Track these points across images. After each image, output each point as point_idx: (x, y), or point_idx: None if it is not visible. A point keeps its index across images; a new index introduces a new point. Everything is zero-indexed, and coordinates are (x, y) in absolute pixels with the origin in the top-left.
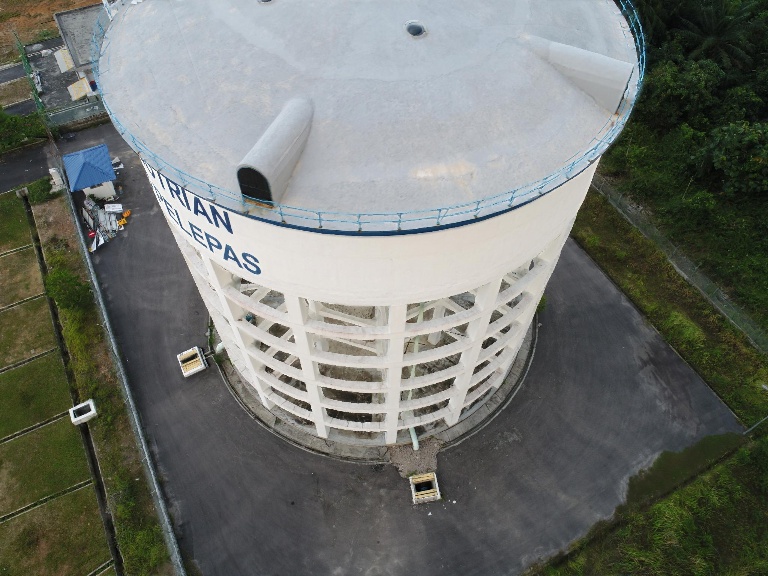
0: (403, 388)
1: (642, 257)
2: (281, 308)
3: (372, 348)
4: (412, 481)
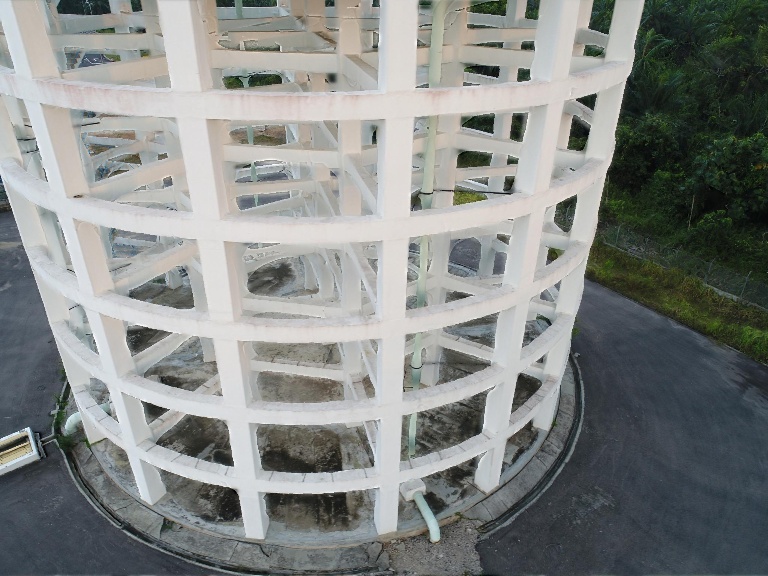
0: (410, 324)
1: (670, 288)
2: (172, 250)
3: (335, 370)
4: None
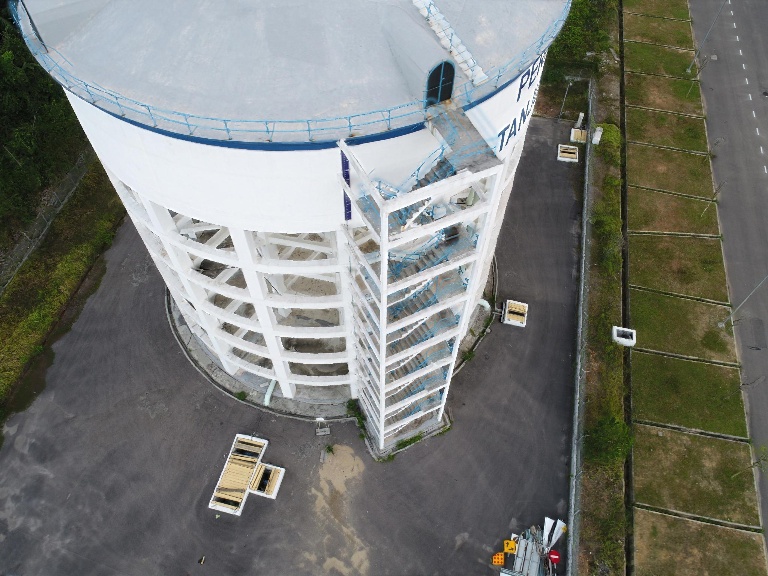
0: None
1: None
2: None
3: None
4: None
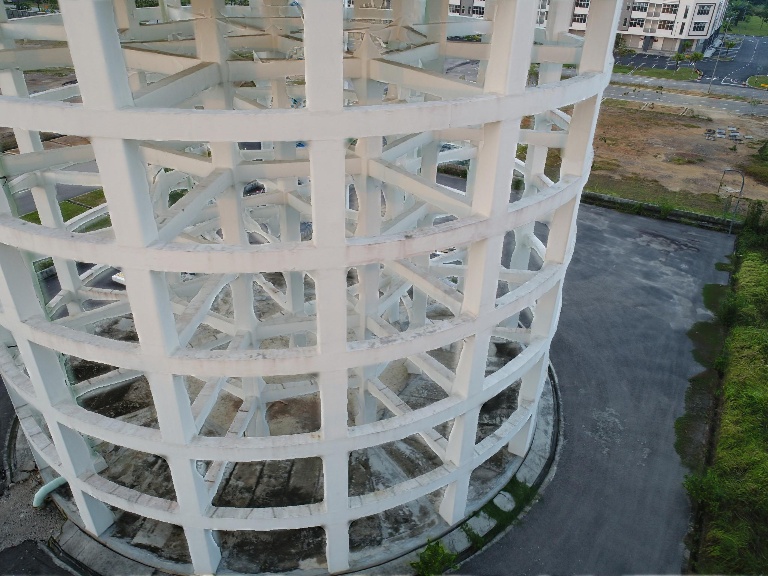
0: None
1: None
2: (98, 174)
3: None
4: None
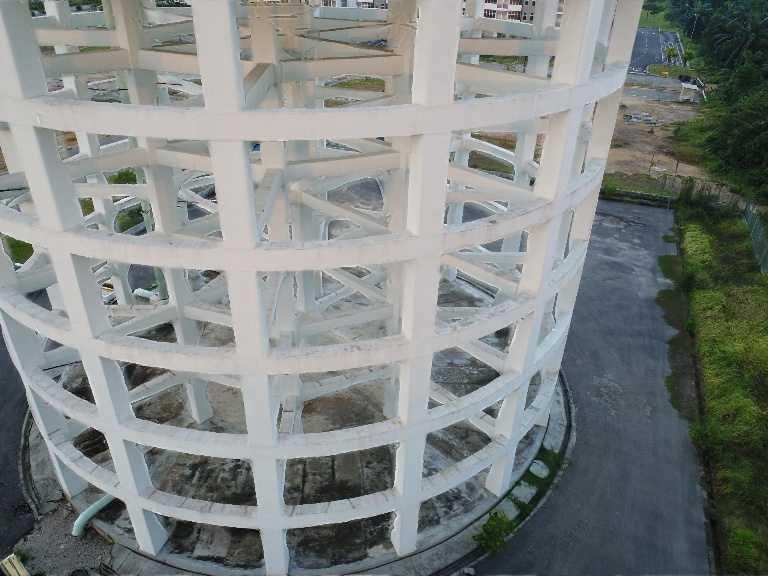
0: None
1: None
2: (95, 184)
3: None
4: (4, 560)
